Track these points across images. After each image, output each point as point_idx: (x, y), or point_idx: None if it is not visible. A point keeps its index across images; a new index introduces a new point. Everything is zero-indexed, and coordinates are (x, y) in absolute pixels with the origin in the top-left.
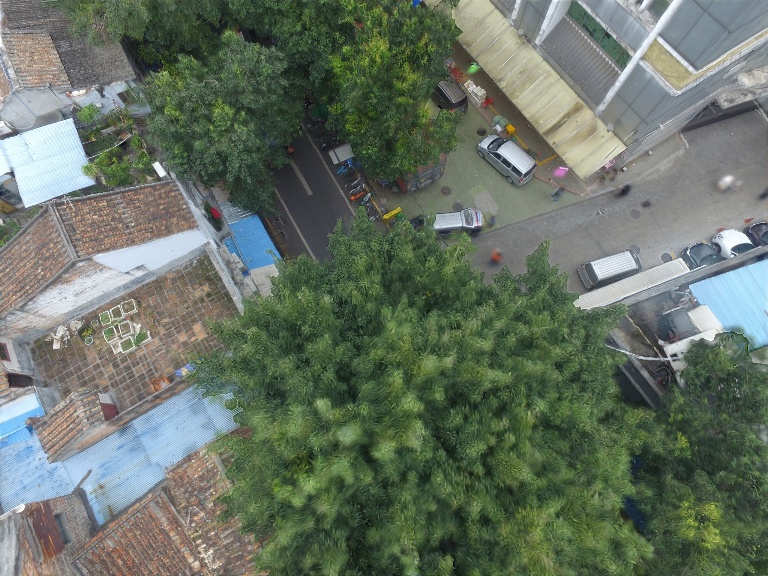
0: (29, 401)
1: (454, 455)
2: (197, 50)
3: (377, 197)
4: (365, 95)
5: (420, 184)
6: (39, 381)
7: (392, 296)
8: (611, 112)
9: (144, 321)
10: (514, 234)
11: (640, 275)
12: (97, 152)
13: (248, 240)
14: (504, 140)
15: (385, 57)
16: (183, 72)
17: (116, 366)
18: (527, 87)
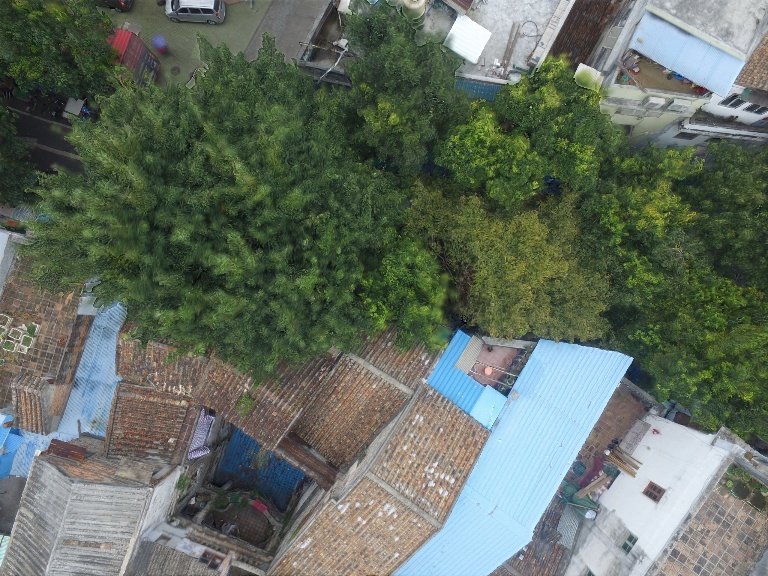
0: None
1: None
2: None
3: None
4: (4, 37)
5: None
6: None
7: None
8: None
9: (24, 320)
10: None
11: None
12: None
13: None
14: None
15: None
16: None
17: (35, 360)
18: None
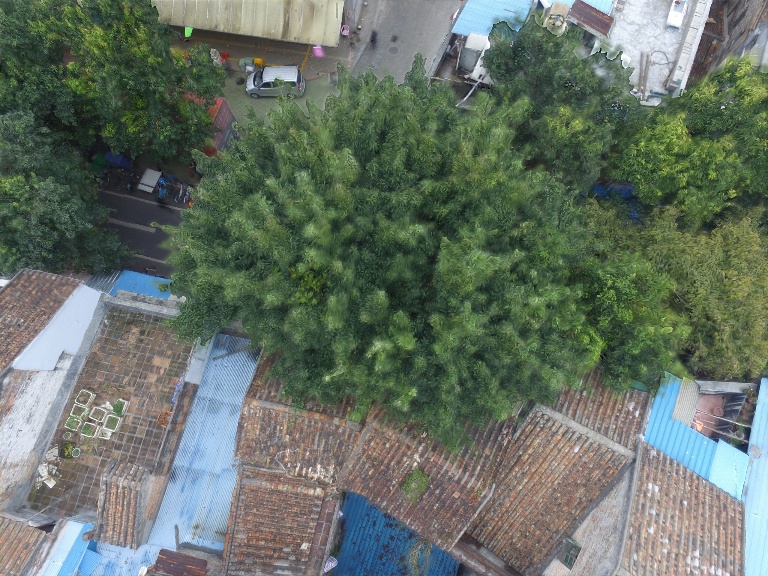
0: (70, 529)
1: None
2: None
3: None
4: (120, 85)
5: None
6: None
7: None
8: None
9: (108, 397)
10: None
11: None
12: None
13: None
14: (261, 71)
15: (107, 40)
16: None
17: (119, 447)
18: (240, 15)
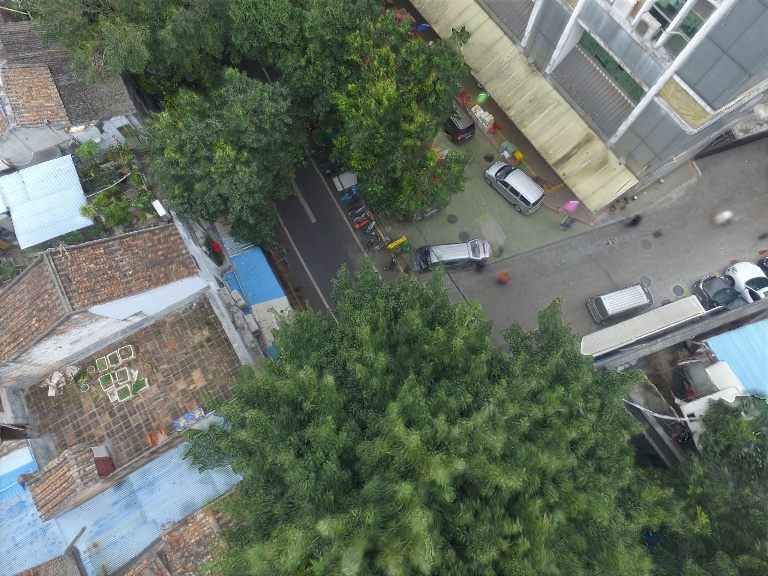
0: (22, 455)
1: (464, 554)
2: (199, 81)
3: (382, 225)
4: (371, 135)
5: (426, 213)
6: (33, 430)
7: (398, 358)
8: (623, 145)
9: (142, 367)
10: (522, 264)
11: (652, 313)
12: (96, 188)
13: (250, 274)
14: (512, 168)
15: (392, 98)
16: (184, 108)
17: (112, 415)
18: (536, 116)
